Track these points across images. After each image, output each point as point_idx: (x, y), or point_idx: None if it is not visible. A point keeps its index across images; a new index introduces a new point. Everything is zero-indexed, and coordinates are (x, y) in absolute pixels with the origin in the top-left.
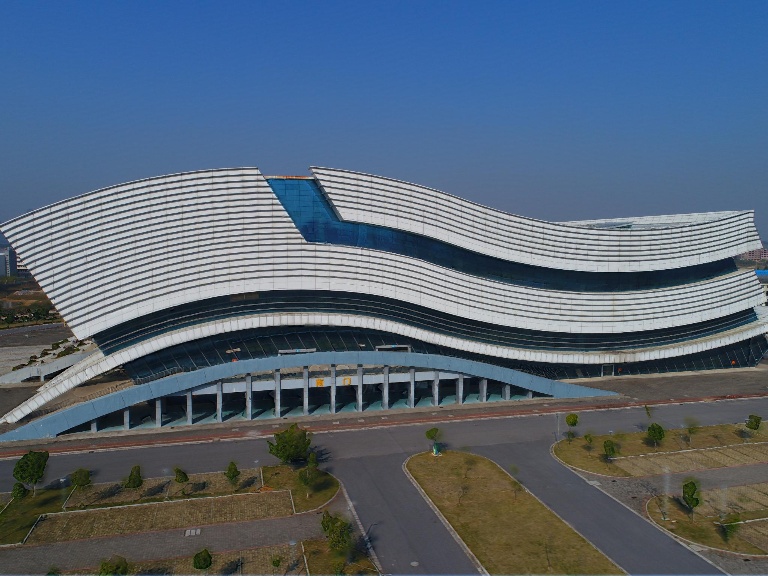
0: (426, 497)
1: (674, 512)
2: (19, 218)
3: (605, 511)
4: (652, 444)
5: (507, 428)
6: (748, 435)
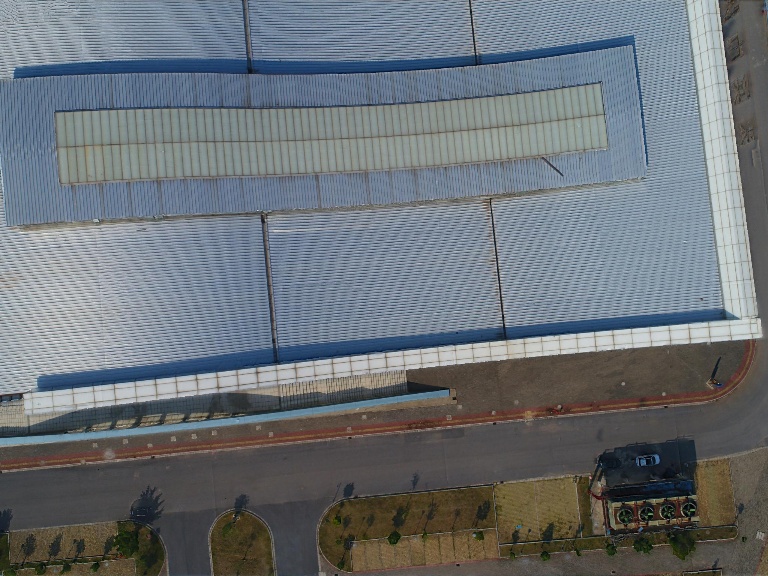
0: None
1: None
2: None
3: None
4: (399, 522)
5: (307, 468)
6: (486, 515)
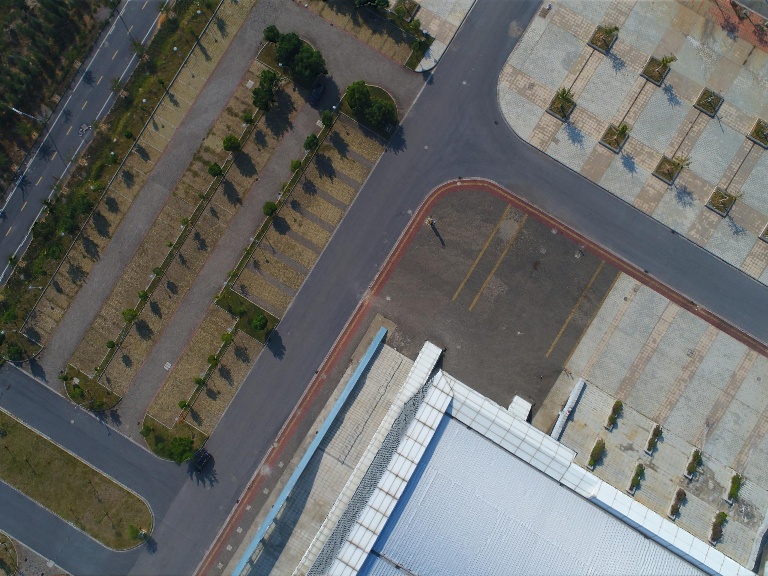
0: (108, 477)
1: (3, 554)
2: (432, 389)
3: (31, 532)
4: None
5: None
6: None
